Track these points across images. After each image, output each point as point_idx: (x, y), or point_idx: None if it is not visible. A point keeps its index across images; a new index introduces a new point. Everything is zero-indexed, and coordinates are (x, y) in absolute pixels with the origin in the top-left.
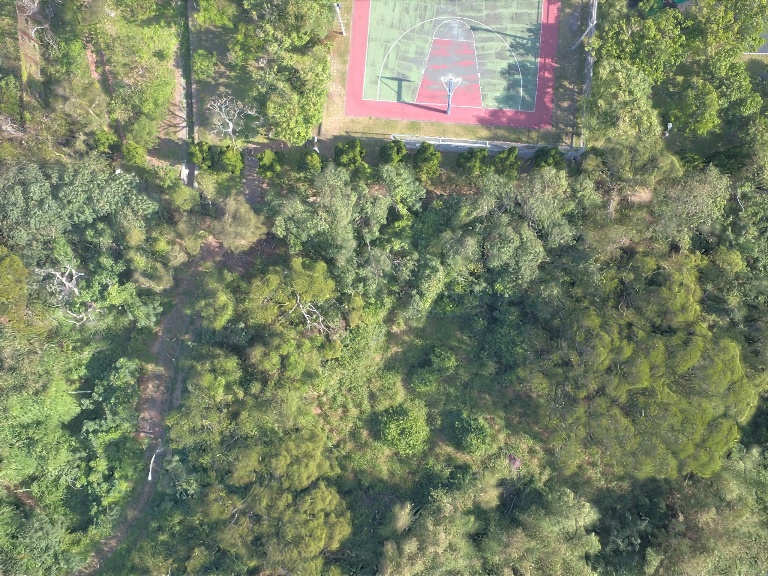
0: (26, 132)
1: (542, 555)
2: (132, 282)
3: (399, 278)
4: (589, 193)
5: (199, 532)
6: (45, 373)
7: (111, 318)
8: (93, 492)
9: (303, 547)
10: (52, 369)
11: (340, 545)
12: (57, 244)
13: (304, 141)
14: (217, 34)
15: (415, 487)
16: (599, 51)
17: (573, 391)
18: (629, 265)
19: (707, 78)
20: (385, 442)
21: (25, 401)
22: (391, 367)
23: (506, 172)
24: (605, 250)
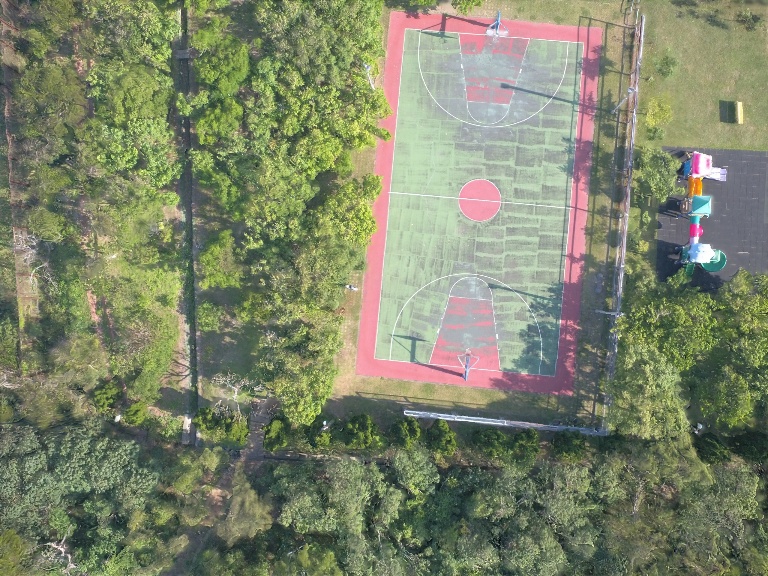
0: (23, 380)
1: None
2: None
3: None
4: (612, 493)
5: None
6: None
7: None
8: None
9: None
10: None
11: None
12: (53, 515)
13: (312, 420)
14: None
15: None
16: (625, 332)
17: None
18: None
19: (739, 366)
20: None
21: None
22: None
23: (525, 460)
24: (629, 558)
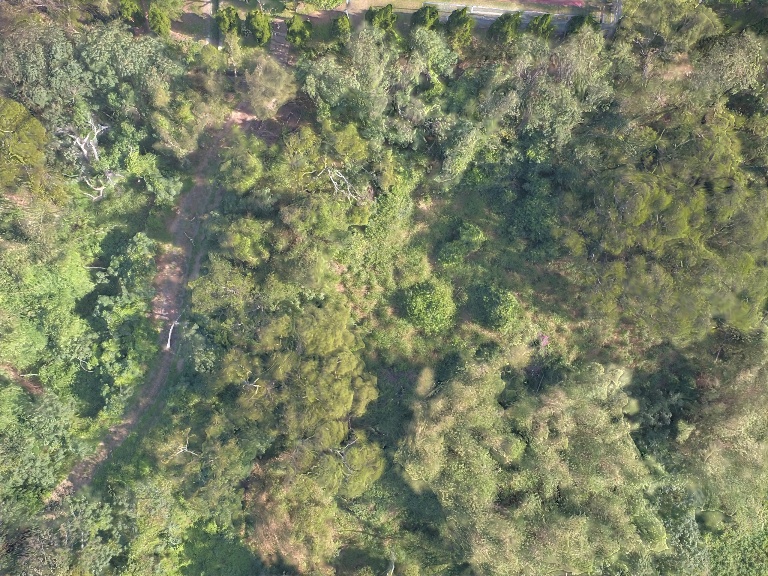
0: (46, 2)
1: (578, 411)
2: (152, 153)
3: (429, 145)
4: (623, 56)
5: None
6: (61, 239)
7: (128, 196)
8: (105, 373)
9: (331, 405)
10: (67, 239)
11: (364, 420)
12: (77, 107)
13: (335, 4)
14: None
15: (440, 367)
16: None
17: (608, 251)
18: (662, 132)
19: None
20: (410, 319)
21: (39, 269)
22: (417, 243)
23: (539, 39)
24: (640, 111)
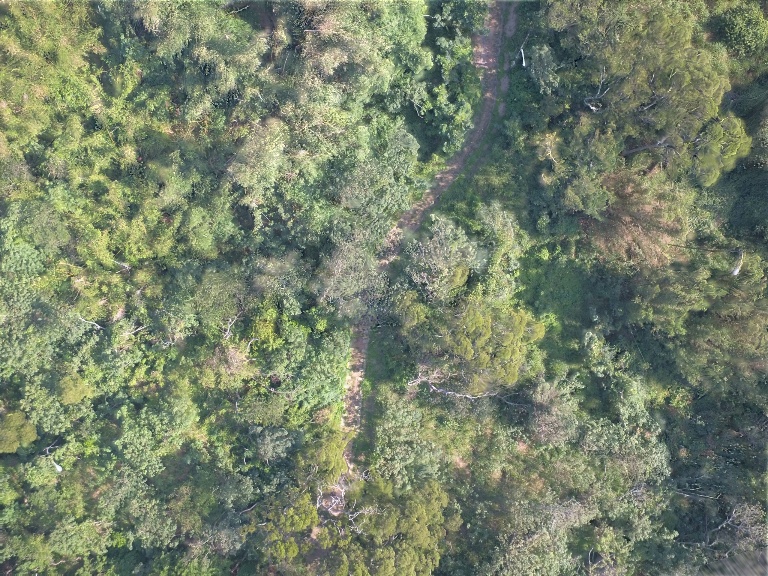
0: None
1: None
2: None
3: None
4: None
5: (543, 148)
6: None
7: None
8: (440, 114)
9: (703, 87)
10: None
11: None
12: None
13: None
14: None
15: (754, 86)
16: None
17: None
18: None
19: None
20: (726, 42)
21: (391, 7)
22: None
23: None
24: None
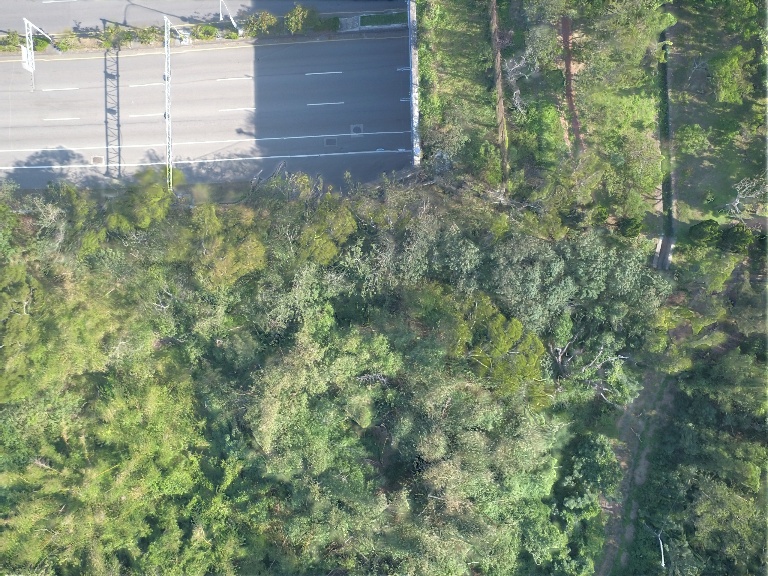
0: None
1: None
2: (620, 358)
3: None
4: None
5: None
6: (547, 451)
7: (575, 391)
8: (561, 569)
9: None
10: None
11: None
12: (563, 320)
13: None
14: (702, 107)
15: None
16: None
17: None
18: None
19: None
20: None
21: (523, 479)
22: None
23: None
24: None
